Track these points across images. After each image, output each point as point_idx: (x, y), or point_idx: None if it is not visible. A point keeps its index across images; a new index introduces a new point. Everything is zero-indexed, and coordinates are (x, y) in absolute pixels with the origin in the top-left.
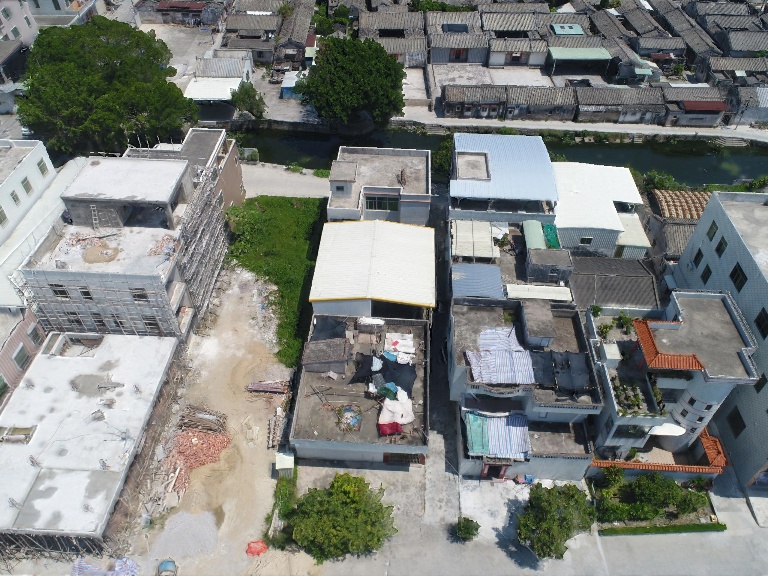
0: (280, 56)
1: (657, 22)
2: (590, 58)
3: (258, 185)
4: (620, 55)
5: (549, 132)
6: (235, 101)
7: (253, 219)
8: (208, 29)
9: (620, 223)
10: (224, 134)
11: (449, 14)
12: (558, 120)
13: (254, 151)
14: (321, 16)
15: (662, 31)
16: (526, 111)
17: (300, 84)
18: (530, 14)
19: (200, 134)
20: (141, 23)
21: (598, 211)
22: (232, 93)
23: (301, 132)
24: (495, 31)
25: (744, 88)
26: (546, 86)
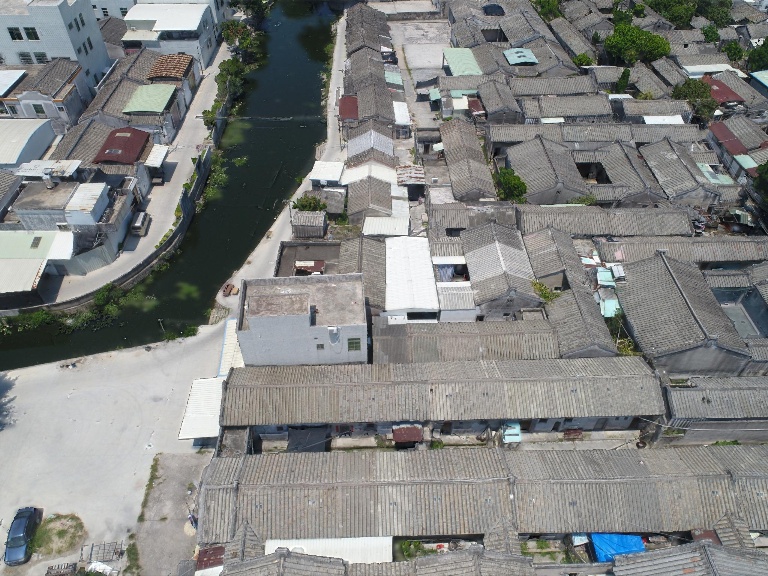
0: None
1: None
2: (450, 65)
3: None
4: None
5: None
6: None
7: None
8: None
9: (132, 19)
10: None
11: (516, 3)
12: None
13: None
14: None
15: None
16: None
17: None
18: None
19: None
20: None
21: (145, 13)
22: None
23: None
24: None
25: (371, 123)
26: None
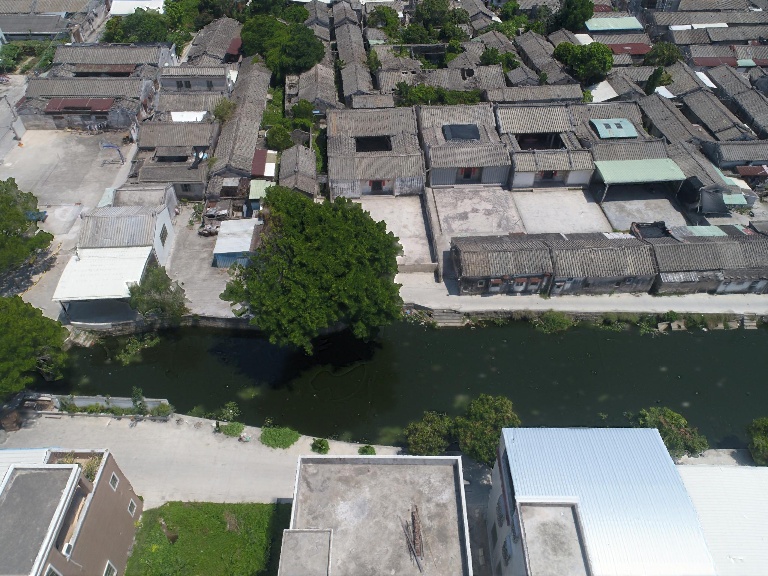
0: (214, 193)
1: (723, 104)
2: (656, 179)
3: (167, 474)
4: (698, 174)
5: (618, 316)
6: (135, 302)
7: (152, 568)
8: (113, 145)
9: None
10: (75, 475)
11: (451, 110)
12: (628, 292)
13: (162, 404)
14: (276, 106)
15: (744, 129)
16: (582, 284)
17: (234, 289)
18: (561, 107)
19: (29, 477)
20: (25, 129)
21: None
22: (130, 288)
23: (244, 331)
24: (516, 134)
25: None
26: (605, 236)
